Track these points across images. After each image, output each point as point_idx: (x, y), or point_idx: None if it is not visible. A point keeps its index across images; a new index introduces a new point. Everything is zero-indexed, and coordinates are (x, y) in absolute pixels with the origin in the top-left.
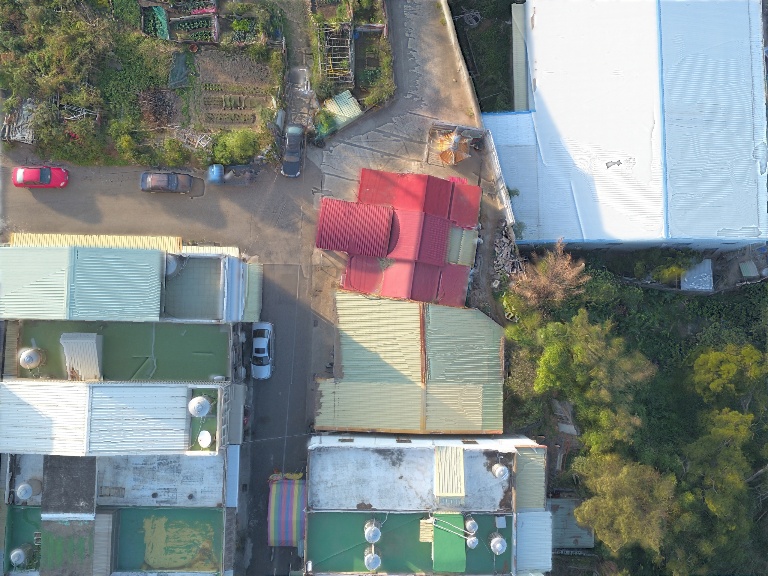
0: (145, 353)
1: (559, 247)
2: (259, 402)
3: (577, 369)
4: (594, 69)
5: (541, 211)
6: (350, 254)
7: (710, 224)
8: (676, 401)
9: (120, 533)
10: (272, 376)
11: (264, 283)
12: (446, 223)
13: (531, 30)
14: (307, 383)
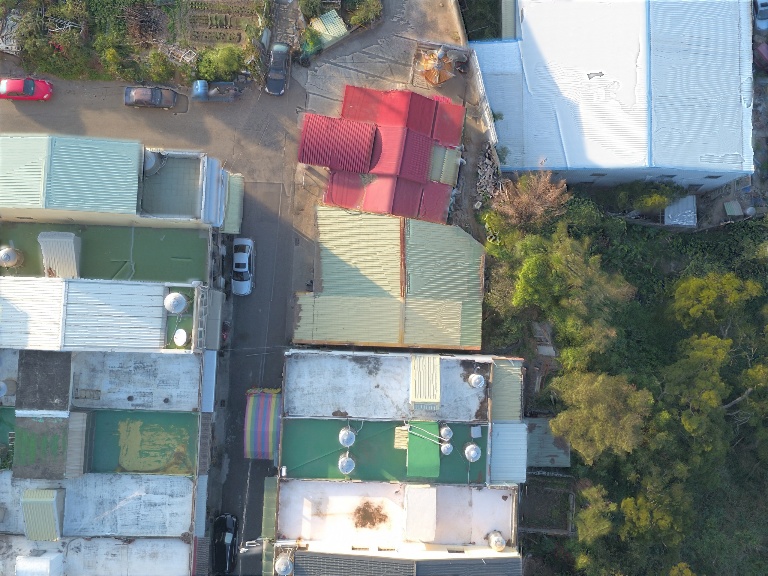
0: (123, 257)
1: None
2: (239, 318)
3: (556, 284)
4: None
5: (526, 139)
6: (332, 170)
7: (695, 160)
8: (657, 334)
9: (95, 435)
10: (252, 293)
11: (246, 200)
12: (429, 141)
13: None
14: (287, 301)
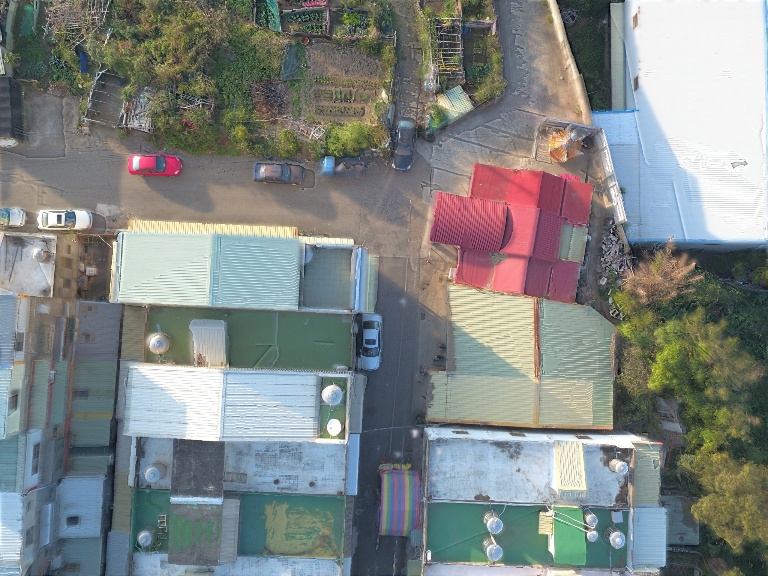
0: (268, 341)
1: (655, 246)
2: (366, 393)
3: (692, 367)
4: (699, 70)
5: (643, 210)
6: (463, 248)
7: None
8: None
9: (242, 518)
10: (380, 367)
11: None
12: (559, 220)
13: (632, 29)
14: (414, 375)
